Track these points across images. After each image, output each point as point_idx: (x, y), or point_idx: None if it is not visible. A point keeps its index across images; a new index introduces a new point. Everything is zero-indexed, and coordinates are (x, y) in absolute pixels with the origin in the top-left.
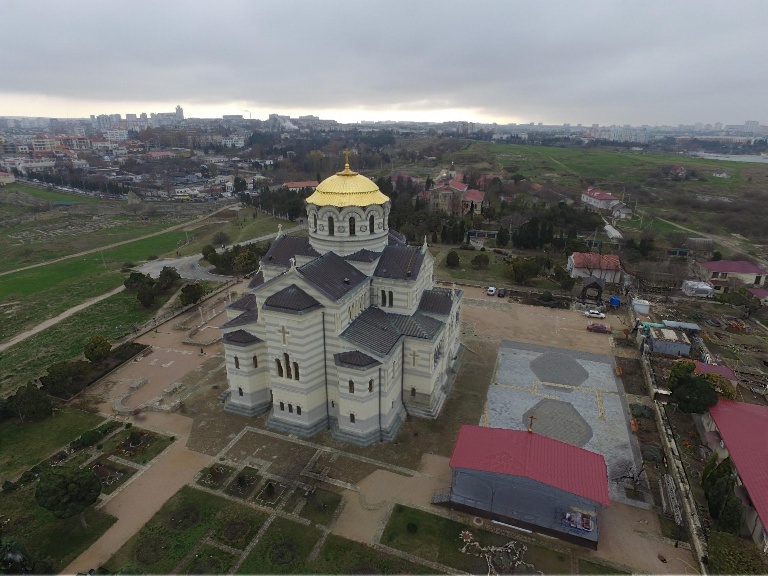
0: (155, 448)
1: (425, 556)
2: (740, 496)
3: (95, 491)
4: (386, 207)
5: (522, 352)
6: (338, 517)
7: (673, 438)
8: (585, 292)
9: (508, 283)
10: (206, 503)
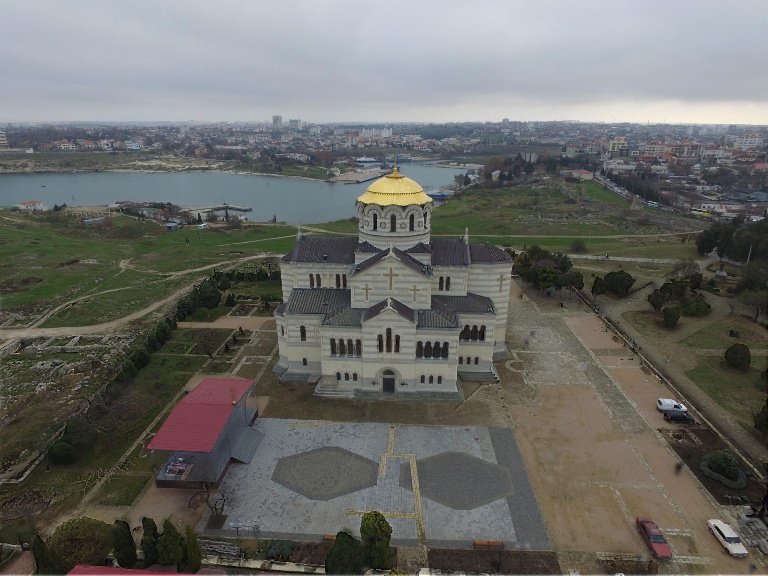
0: (264, 314)
1: (171, 407)
2: (156, 570)
3: (210, 303)
4: (396, 211)
5: (485, 444)
6: (207, 374)
7: (307, 571)
8: (767, 496)
9: (747, 424)
10: (221, 337)
